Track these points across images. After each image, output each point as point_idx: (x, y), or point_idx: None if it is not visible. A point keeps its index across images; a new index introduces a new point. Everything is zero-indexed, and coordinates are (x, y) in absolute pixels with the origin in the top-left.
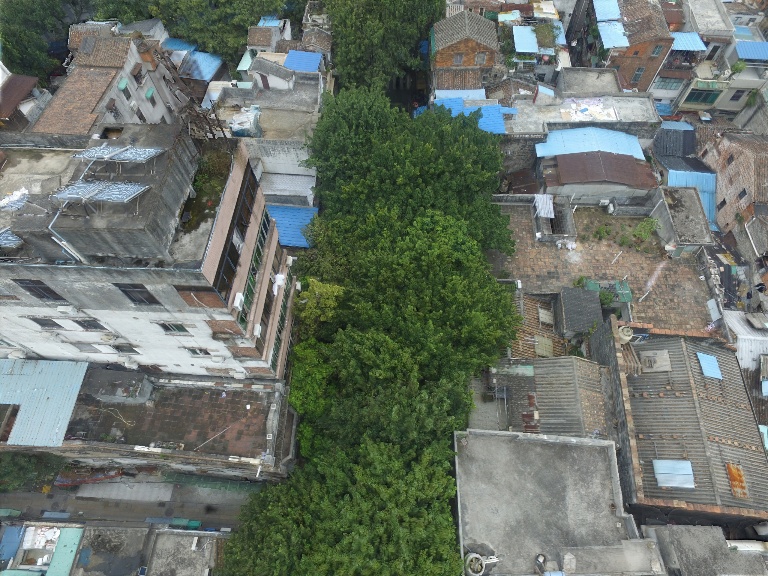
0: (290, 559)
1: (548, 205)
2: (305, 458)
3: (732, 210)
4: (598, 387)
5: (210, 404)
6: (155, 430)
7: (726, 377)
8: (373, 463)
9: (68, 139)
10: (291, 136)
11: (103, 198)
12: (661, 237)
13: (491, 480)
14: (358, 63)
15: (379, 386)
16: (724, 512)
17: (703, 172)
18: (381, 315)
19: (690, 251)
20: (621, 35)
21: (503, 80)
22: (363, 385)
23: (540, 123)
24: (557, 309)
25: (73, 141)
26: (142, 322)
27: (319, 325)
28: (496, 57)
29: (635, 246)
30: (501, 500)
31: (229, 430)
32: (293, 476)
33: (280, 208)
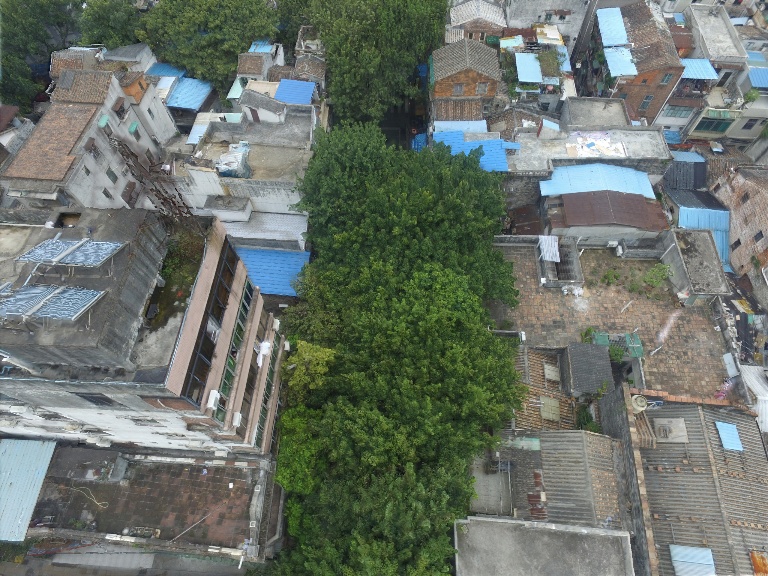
0: None
1: (553, 247)
2: (293, 536)
3: (747, 252)
4: (610, 465)
5: (190, 482)
6: (129, 513)
7: (747, 447)
8: (364, 566)
9: (25, 215)
10: (281, 175)
11: (47, 315)
12: (673, 283)
13: (494, 575)
14: (353, 92)
15: (372, 474)
16: None
17: (716, 209)
18: (375, 385)
19: (704, 298)
20: (629, 62)
21: (505, 110)
22: (355, 467)
23: (544, 159)
24: (564, 364)
25: (31, 216)
26: (108, 416)
27: (309, 391)
28: (498, 86)
29: (646, 292)
30: None
31: None
32: (279, 565)
33: (270, 252)
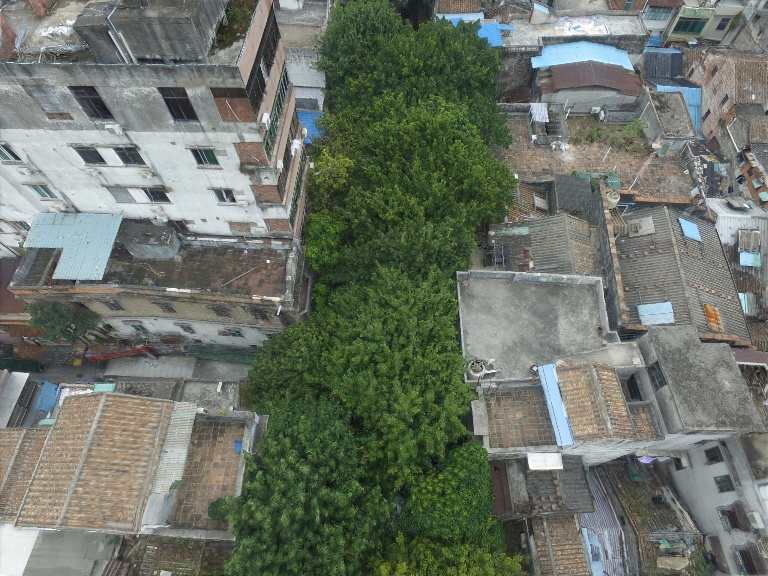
0: (311, 363)
1: (543, 111)
2: None
3: (716, 117)
4: (587, 241)
5: (233, 259)
6: (184, 279)
7: (706, 242)
8: (384, 283)
9: None
10: (302, 46)
11: None
12: (648, 137)
13: (490, 312)
14: None
15: None
16: (700, 337)
17: (689, 87)
18: (389, 178)
19: (676, 150)
20: None
21: (501, 6)
22: (374, 233)
23: (535, 39)
24: (551, 197)
25: None
26: (178, 149)
27: (331, 197)
28: None
29: (624, 146)
30: (499, 327)
31: (251, 279)
32: None
33: None
